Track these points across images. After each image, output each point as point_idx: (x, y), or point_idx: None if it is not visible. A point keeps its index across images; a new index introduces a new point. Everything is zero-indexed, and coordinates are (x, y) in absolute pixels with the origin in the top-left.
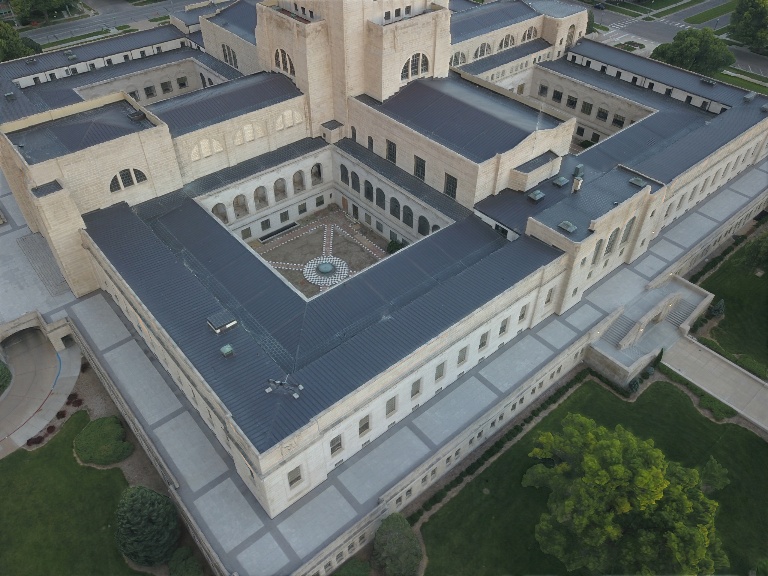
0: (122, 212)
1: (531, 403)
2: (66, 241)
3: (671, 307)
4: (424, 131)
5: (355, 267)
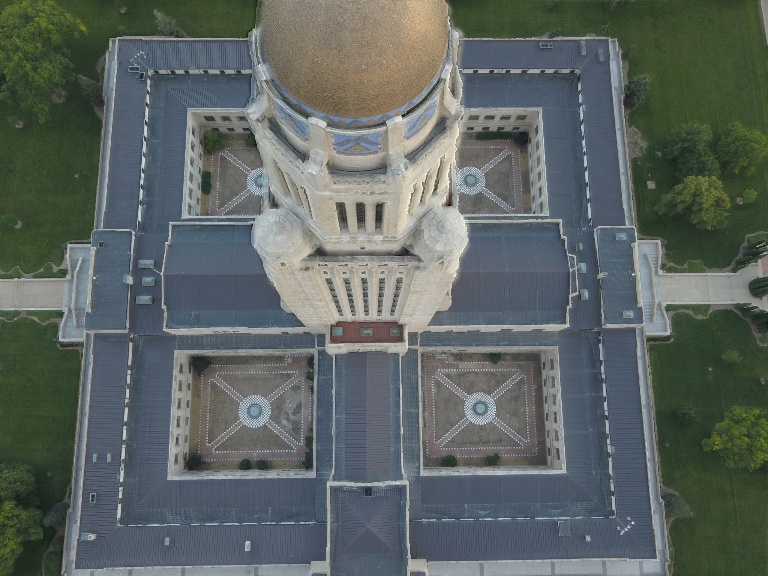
0: (417, 529)
1: None
2: None
3: None
4: (500, 314)
5: (489, 390)
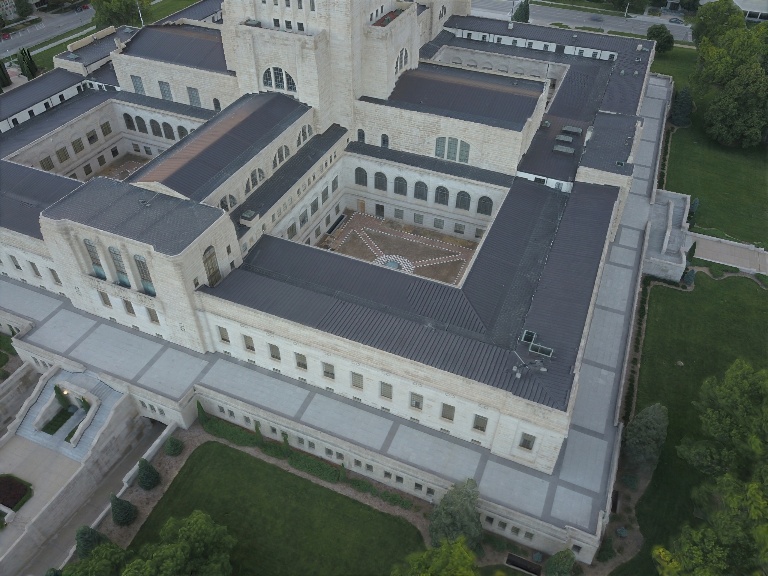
0: None
1: None
2: None
3: None
4: None
5: None
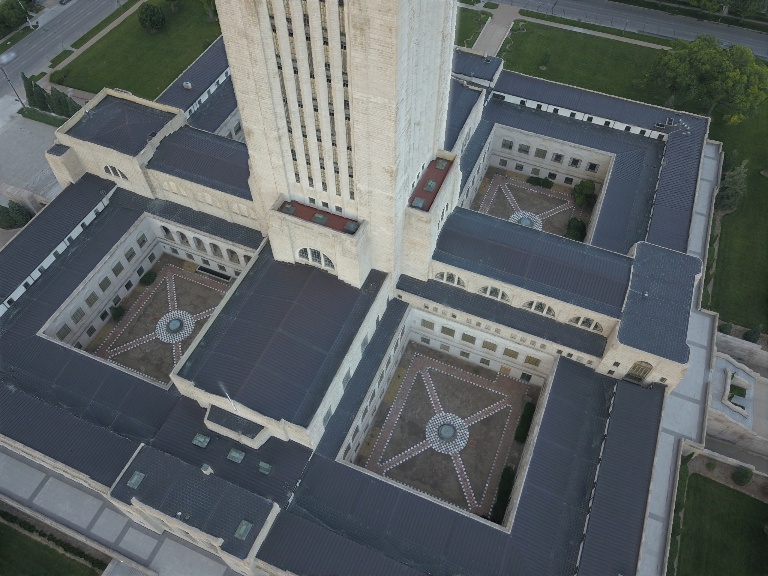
0: (103, 188)
1: (61, 531)
2: (64, 182)
3: None
4: (237, 311)
5: (186, 344)
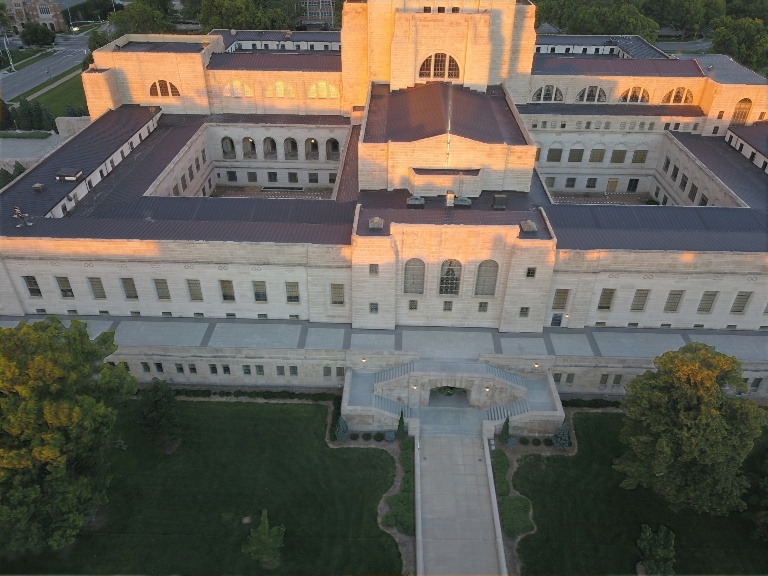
0: (149, 111)
1: (248, 385)
2: (98, 114)
3: (502, 399)
4: (383, 117)
5: None
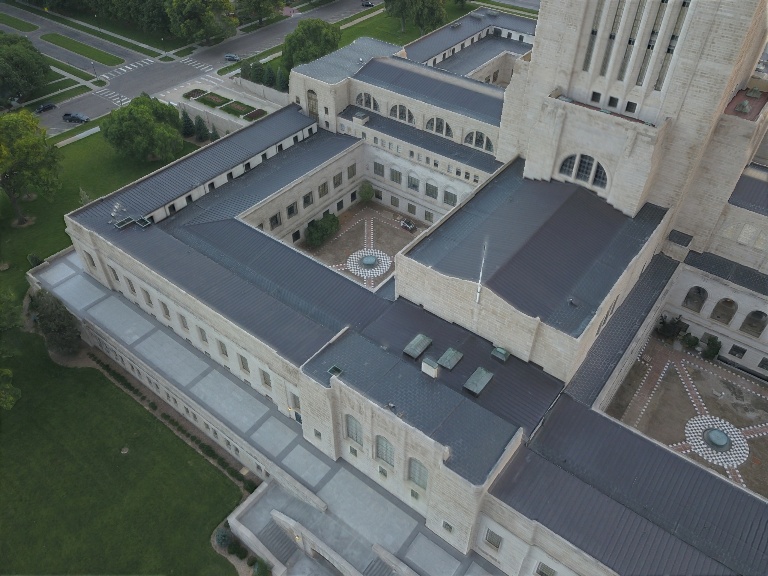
0: None
1: None
2: None
3: None
4: None
5: None
